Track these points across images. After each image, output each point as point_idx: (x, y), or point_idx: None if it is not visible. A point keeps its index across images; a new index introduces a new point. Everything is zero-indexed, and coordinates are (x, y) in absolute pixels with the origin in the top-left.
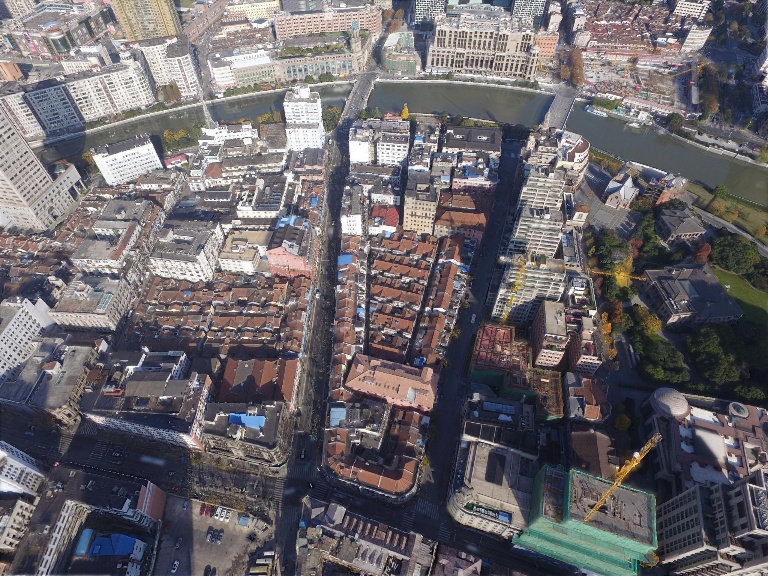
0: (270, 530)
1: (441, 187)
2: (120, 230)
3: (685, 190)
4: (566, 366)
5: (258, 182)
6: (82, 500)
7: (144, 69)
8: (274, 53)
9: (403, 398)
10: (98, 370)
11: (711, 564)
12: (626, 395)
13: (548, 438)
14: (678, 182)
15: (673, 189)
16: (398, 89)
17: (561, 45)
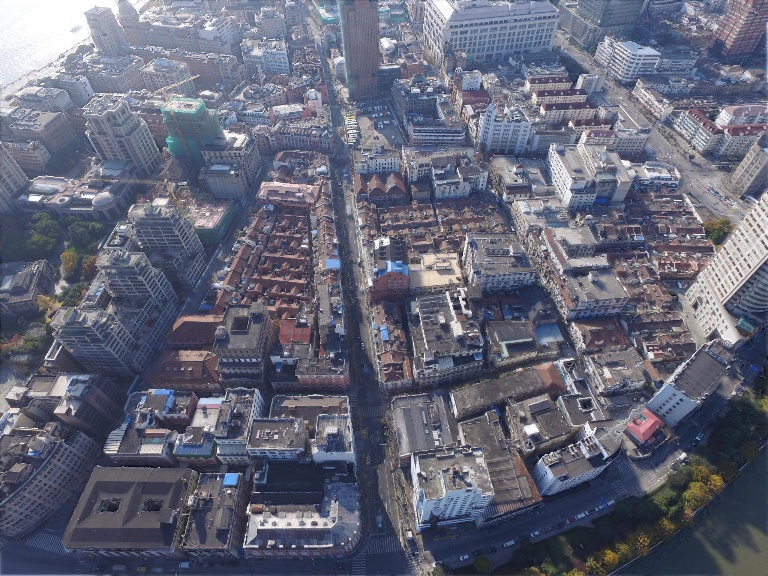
0: None
1: None
2: None
3: None
4: None
5: (459, 328)
6: None
7: None
8: None
9: None
10: None
11: None
12: None
13: None
14: None
15: None
16: None
17: None
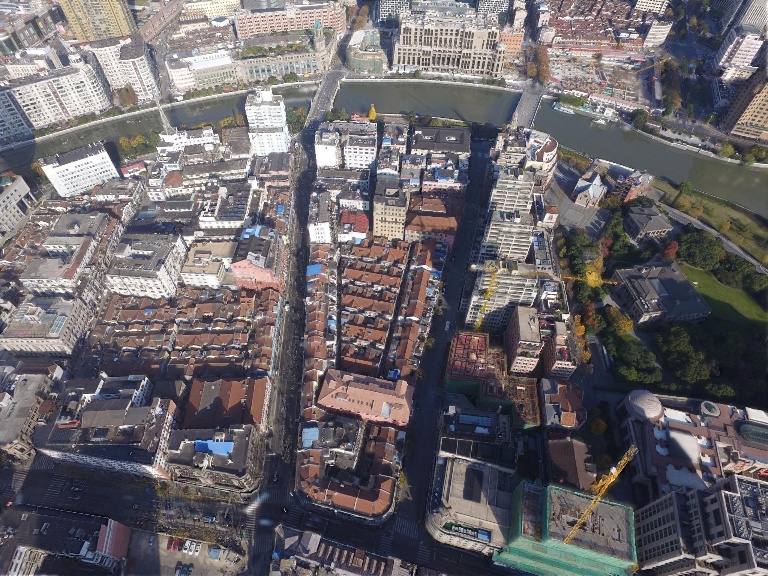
0: (243, 561)
1: (411, 190)
2: (73, 246)
3: (652, 186)
4: (541, 371)
5: (221, 191)
6: (35, 545)
7: (96, 72)
8: (235, 53)
9: (377, 414)
10: (51, 400)
11: (689, 572)
12: (601, 398)
13: (525, 447)
14: (645, 179)
15: (640, 186)
16: (365, 88)
17: (527, 41)
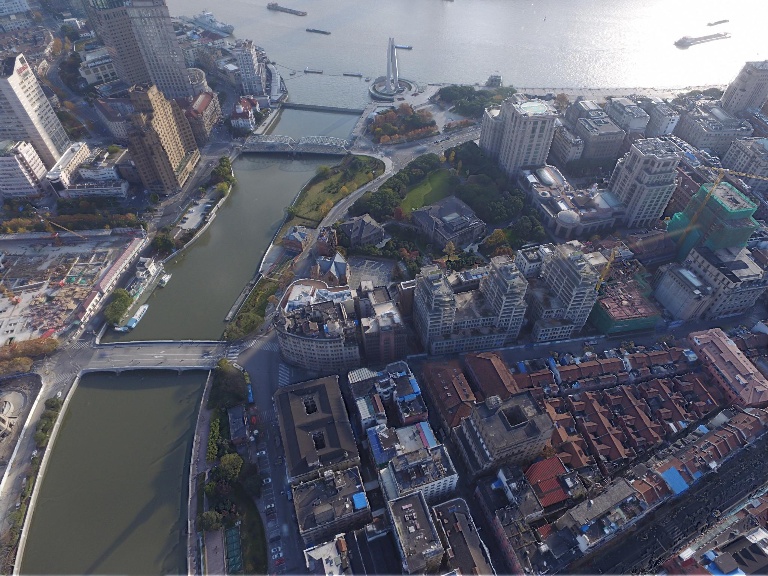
0: None
1: None
2: None
3: None
4: None
5: None
6: None
7: None
8: None
9: None
10: None
11: None
12: None
13: None
14: (303, 230)
15: None
16: None
17: None
